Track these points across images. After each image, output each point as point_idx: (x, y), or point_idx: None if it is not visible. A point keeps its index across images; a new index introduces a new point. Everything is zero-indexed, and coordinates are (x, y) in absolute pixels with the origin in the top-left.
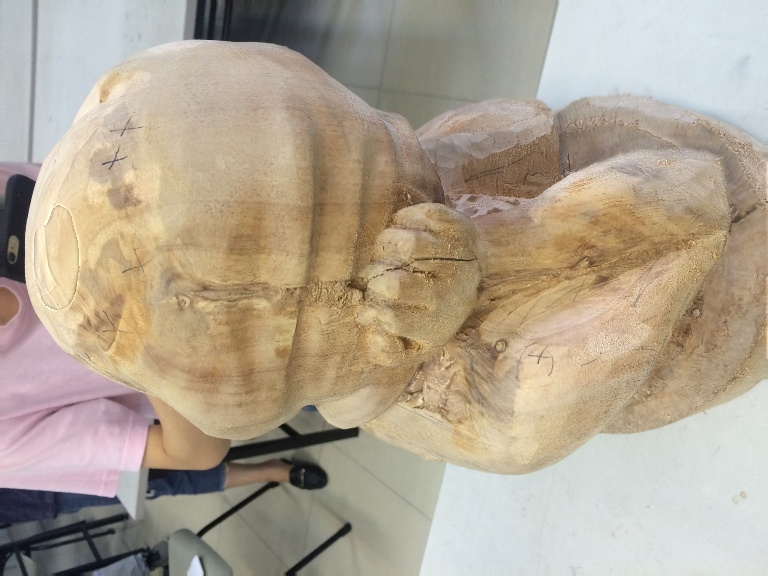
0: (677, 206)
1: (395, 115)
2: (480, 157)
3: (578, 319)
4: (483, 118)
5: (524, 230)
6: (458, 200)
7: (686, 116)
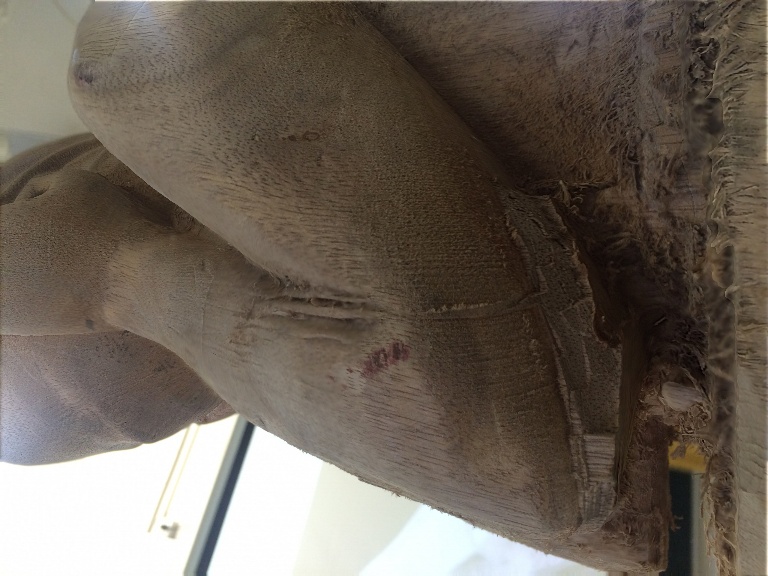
0: None
1: None
2: None
3: None
4: None
5: None
6: None
7: None
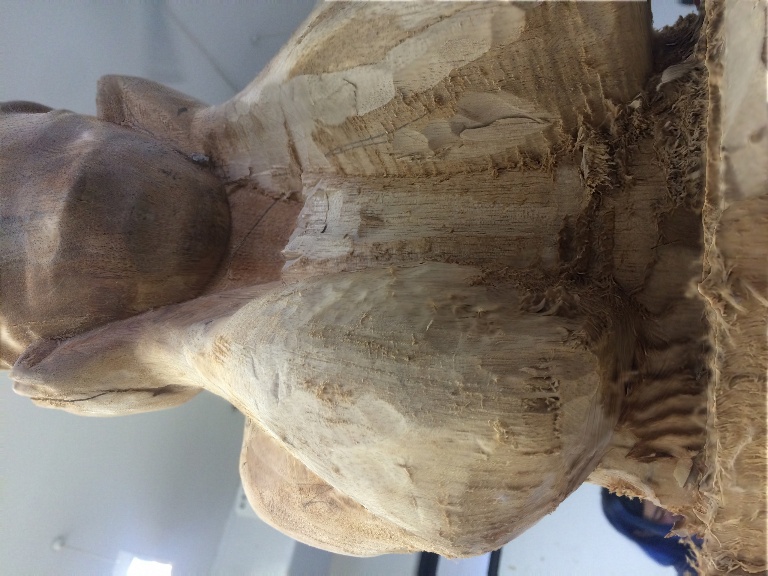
0: (315, 468)
1: (53, 203)
2: (333, 123)
3: (274, 462)
4: (346, 34)
5: (183, 365)
6: (313, 187)
7: (763, 148)
